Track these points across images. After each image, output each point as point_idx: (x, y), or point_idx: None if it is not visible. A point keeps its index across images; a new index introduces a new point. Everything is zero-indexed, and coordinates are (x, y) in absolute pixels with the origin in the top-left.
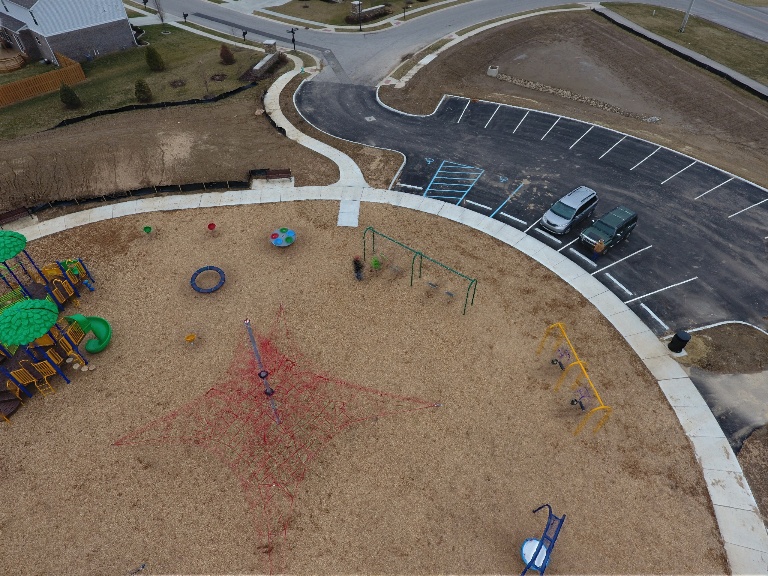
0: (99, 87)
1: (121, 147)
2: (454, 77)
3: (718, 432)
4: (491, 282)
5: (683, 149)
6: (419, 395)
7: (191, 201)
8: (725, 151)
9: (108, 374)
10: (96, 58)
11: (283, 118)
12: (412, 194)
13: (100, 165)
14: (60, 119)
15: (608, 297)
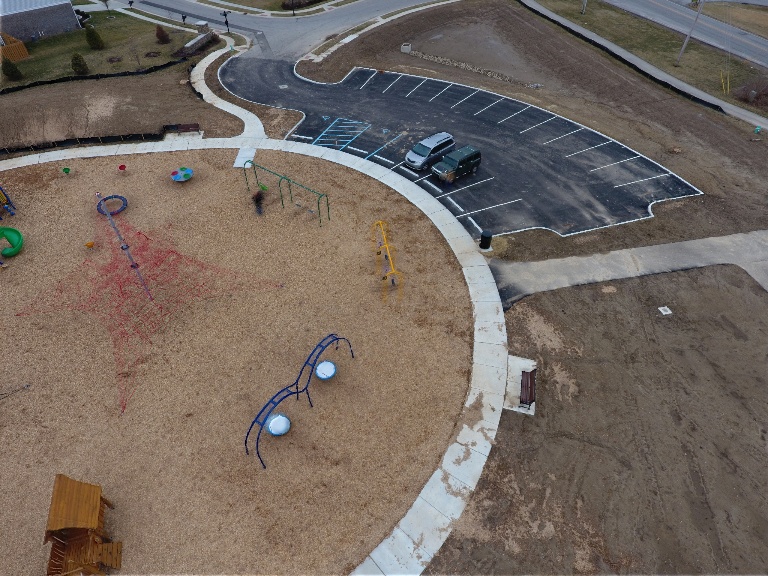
0: (41, 63)
1: (50, 107)
2: (369, 53)
3: (496, 298)
4: (351, 204)
5: (548, 107)
6: (269, 280)
7: (109, 150)
8: (587, 109)
9: (18, 271)
10: (41, 39)
11: (205, 86)
12: (303, 143)
13: (30, 122)
14: (2, 89)
15: (444, 213)
